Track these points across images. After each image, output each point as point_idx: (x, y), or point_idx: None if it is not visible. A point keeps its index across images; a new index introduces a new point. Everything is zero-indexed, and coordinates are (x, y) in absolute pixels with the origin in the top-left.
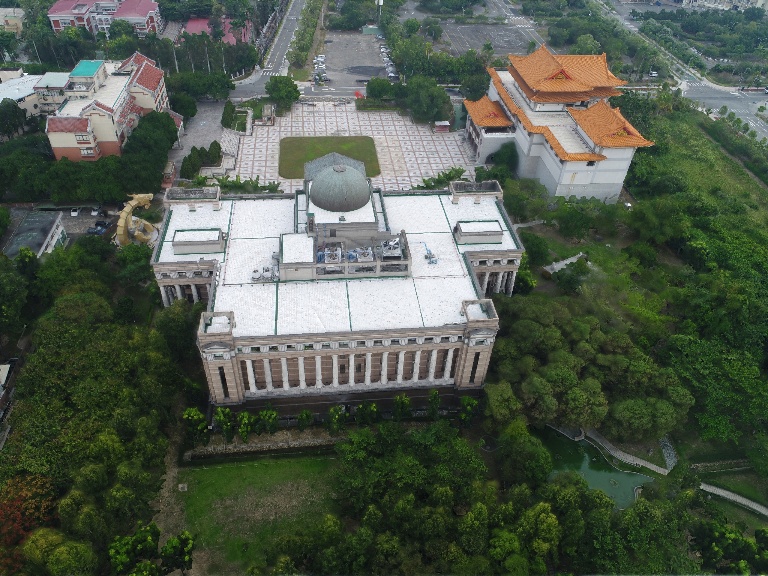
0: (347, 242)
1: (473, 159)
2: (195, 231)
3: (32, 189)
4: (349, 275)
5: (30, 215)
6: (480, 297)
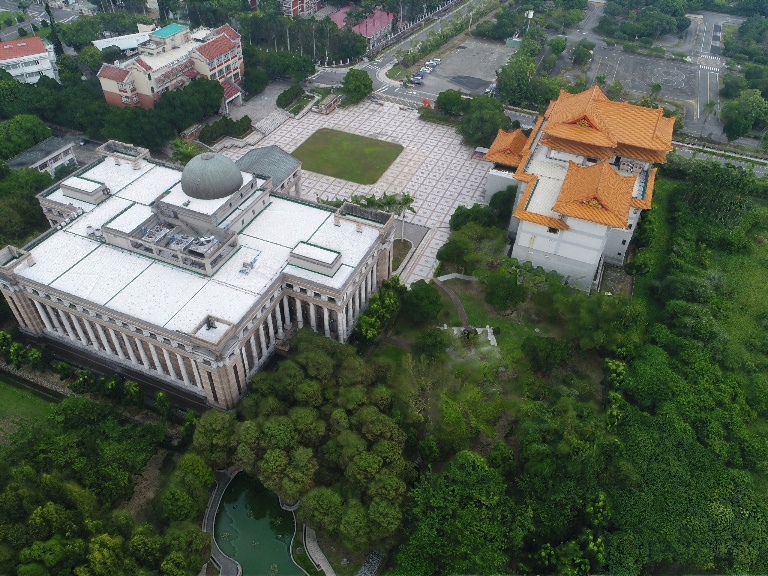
0: (184, 227)
1: (483, 195)
2: (85, 180)
3: (73, 120)
4: (158, 257)
5: (53, 139)
6: (241, 319)
